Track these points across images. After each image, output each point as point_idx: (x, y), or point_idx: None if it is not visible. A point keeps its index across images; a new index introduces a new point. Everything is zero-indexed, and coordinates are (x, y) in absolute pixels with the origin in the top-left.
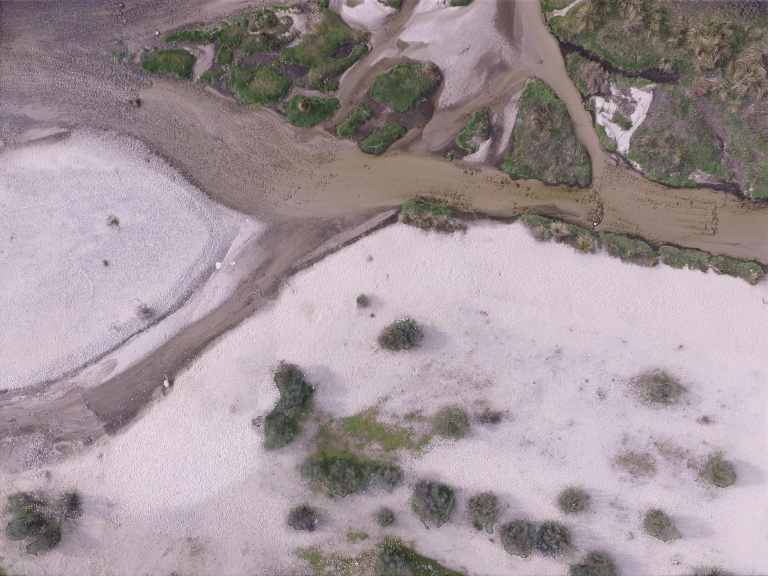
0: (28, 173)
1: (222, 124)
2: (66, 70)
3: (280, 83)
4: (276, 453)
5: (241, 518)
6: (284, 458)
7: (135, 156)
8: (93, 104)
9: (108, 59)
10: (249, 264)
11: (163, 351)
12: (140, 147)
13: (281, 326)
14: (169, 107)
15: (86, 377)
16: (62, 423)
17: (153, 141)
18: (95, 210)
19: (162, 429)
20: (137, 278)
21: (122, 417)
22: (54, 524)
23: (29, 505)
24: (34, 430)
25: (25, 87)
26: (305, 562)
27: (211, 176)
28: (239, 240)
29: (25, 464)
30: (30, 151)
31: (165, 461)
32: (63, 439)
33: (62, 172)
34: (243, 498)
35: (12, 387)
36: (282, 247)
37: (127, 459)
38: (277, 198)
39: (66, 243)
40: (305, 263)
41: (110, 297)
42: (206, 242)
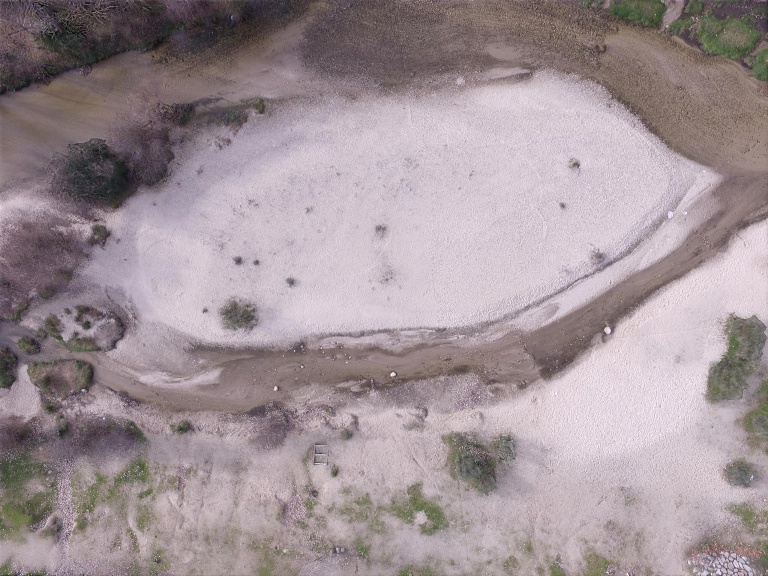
0: (488, 111)
1: (686, 74)
2: (533, 11)
3: (750, 36)
4: (717, 406)
5: (675, 470)
6: (724, 412)
7: (596, 101)
8: (557, 47)
9: (577, 3)
10: (701, 215)
11: (606, 298)
12: (602, 92)
13: (732, 279)
14: (634, 54)
15: (526, 319)
16: (497, 365)
17: (615, 87)
18: (556, 152)
19: (602, 376)
20: (592, 222)
21: (559, 362)
22: (489, 466)
23: (462, 445)
24: (469, 370)
25: (490, 26)
26: (738, 518)
27: (670, 125)
28: (694, 190)
29: (457, 404)
30: (491, 90)
31: (604, 408)
32: (497, 381)
33: (523, 112)
34: (679, 450)
35: (452, 325)
36: (736, 200)
37: (563, 404)
38: (735, 151)
39: (524, 183)
40: (757, 217)
41: (563, 240)
42: (664, 190)
